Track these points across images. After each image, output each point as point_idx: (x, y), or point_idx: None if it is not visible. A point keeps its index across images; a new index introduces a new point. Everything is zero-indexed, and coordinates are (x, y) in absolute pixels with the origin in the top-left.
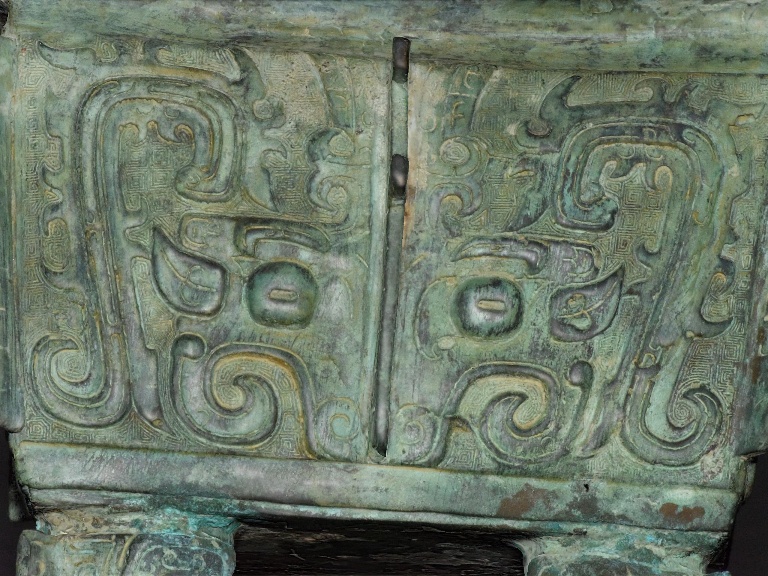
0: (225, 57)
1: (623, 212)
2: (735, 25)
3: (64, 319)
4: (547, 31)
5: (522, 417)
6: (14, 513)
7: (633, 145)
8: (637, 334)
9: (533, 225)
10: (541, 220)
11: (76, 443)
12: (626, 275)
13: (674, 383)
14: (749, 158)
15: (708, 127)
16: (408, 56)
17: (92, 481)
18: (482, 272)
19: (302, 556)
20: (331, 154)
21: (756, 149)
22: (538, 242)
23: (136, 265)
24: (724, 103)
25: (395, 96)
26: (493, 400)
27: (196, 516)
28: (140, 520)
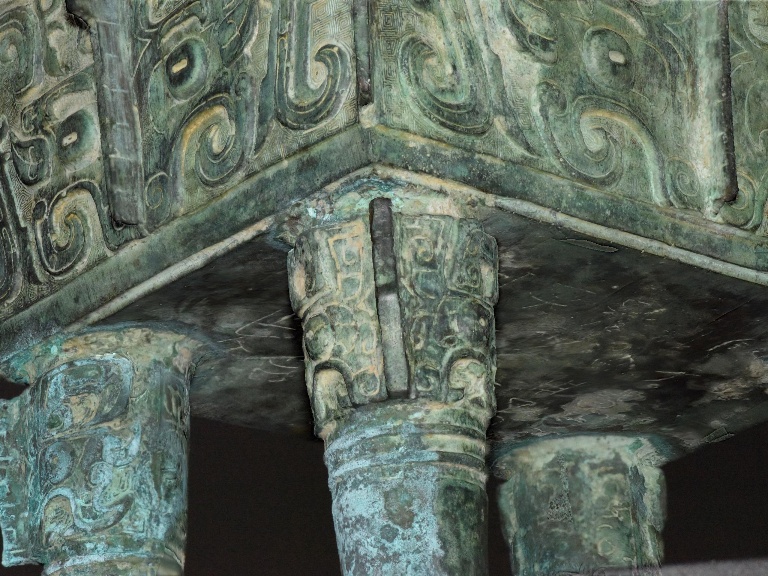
0: None
1: None
2: None
3: None
4: None
5: None
6: None
7: None
8: None
9: None
10: None
11: None
12: None
13: None
14: None
15: None
16: None
17: None
18: None
19: (672, 373)
20: None
21: None
22: None
23: None
24: None
25: None
26: None
27: None
28: None
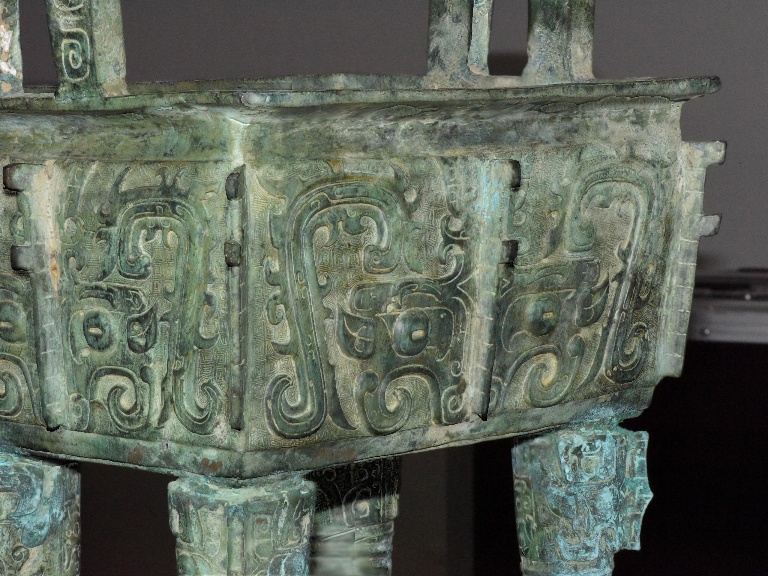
0: None
1: (154, 265)
2: (207, 122)
3: None
4: (126, 129)
5: (128, 401)
6: None
7: (154, 217)
8: (172, 347)
9: (110, 276)
10: (114, 272)
11: None
12: (160, 308)
13: (194, 380)
14: (215, 222)
15: (190, 203)
16: (12, 179)
17: None
18: (94, 307)
19: None
20: (19, 230)
21: (219, 215)
22: (111, 289)
23: None
24: (197, 184)
25: (21, 200)
26: (110, 391)
27: (12, 453)
28: None
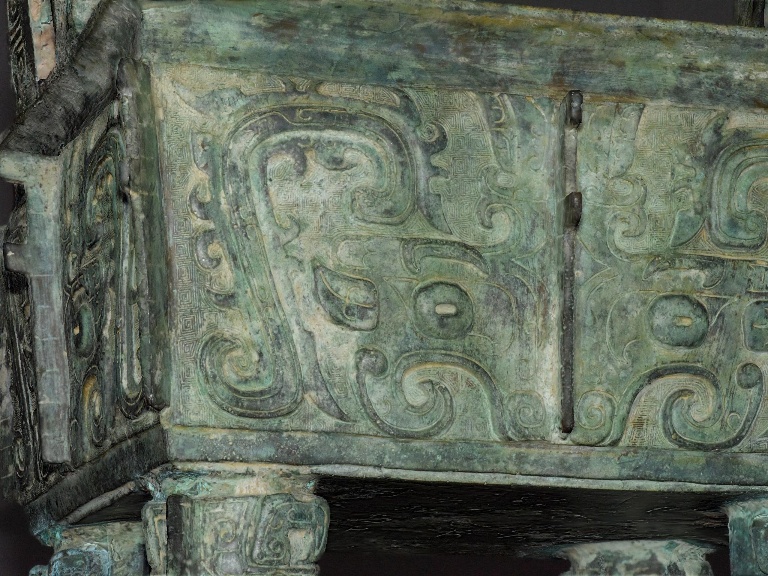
0: None
1: None
2: None
3: None
4: None
5: None
6: None
7: None
8: None
9: None
10: None
11: None
12: None
13: None
14: None
15: None
16: None
17: None
18: None
19: None
20: None
21: None
22: None
23: None
24: None
25: None
26: None
27: None
28: None
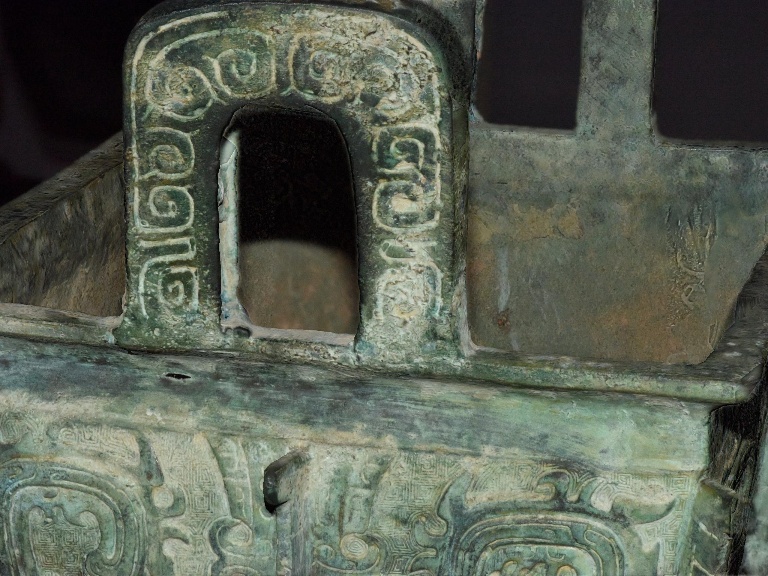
0: (646, 224)
1: None
2: None
3: None
4: None
5: None
6: None
7: None
8: None
9: None
10: None
11: None
12: None
13: None
14: None
15: None
16: None
17: None
18: None
19: None
20: None
21: None
22: None
23: None
24: None
25: None
26: None
27: None
28: None
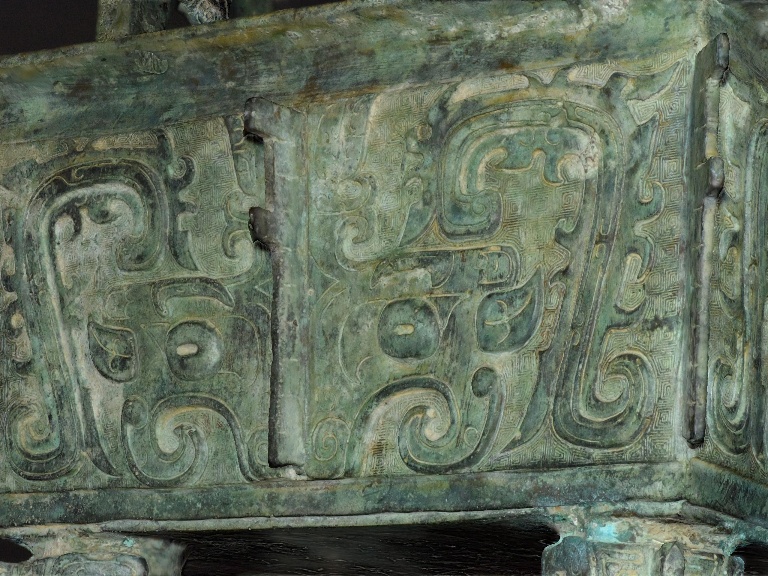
0: None
1: None
2: None
3: (729, 345)
4: None
5: None
6: (282, 457)
7: None
8: None
9: None
10: None
11: (722, 466)
12: None
13: None
14: None
15: None
16: None
17: (721, 503)
18: None
19: None
20: None
21: None
22: None
23: (766, 304)
24: None
25: None
26: None
27: None
28: (724, 542)
